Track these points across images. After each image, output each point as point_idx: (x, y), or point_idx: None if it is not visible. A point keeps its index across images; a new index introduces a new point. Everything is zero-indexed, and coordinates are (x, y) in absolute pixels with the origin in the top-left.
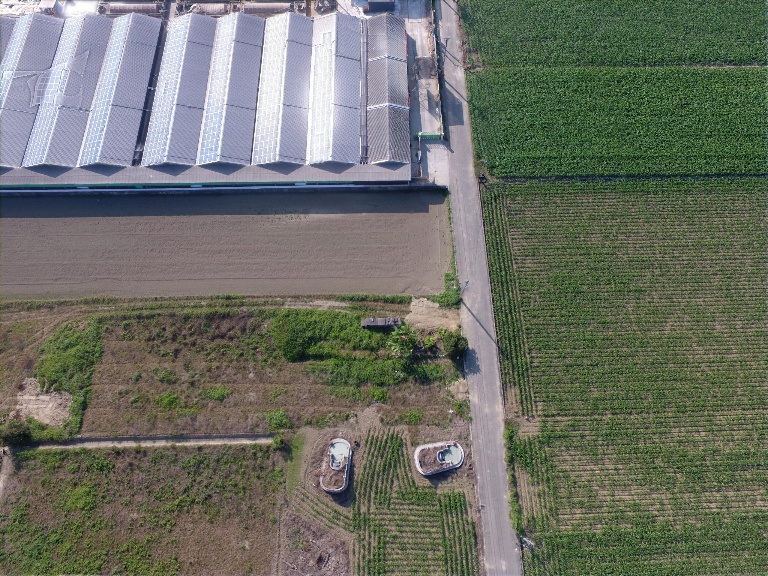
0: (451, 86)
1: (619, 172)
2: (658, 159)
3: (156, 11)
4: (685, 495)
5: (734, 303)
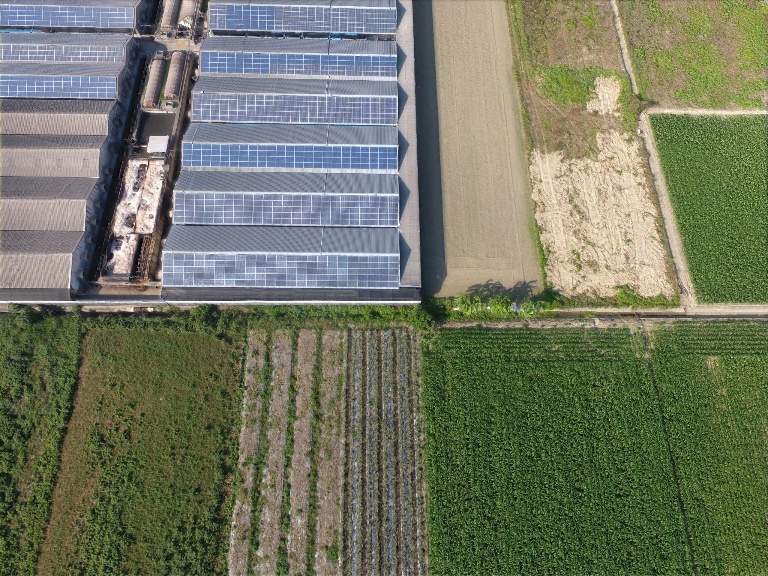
0: None
1: None
2: None
3: (184, 54)
4: None
5: None
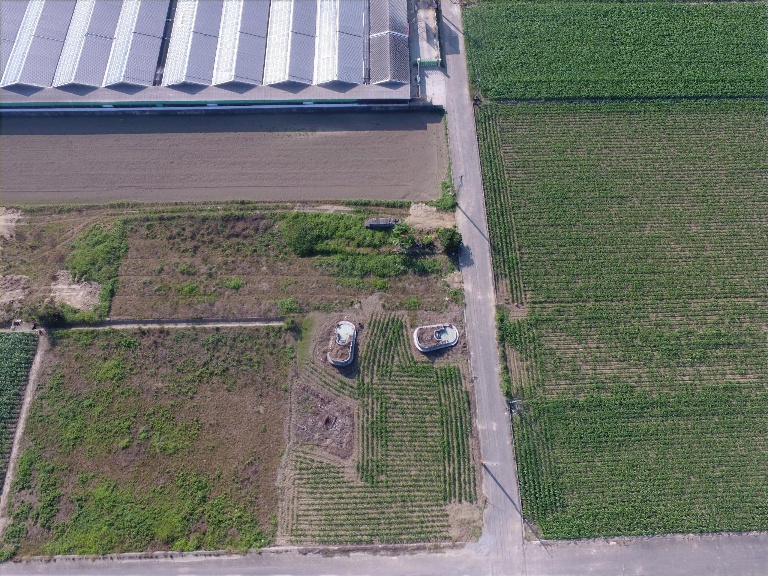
0: (448, 20)
1: (604, 94)
2: (641, 83)
3: None
4: (661, 369)
5: (709, 208)
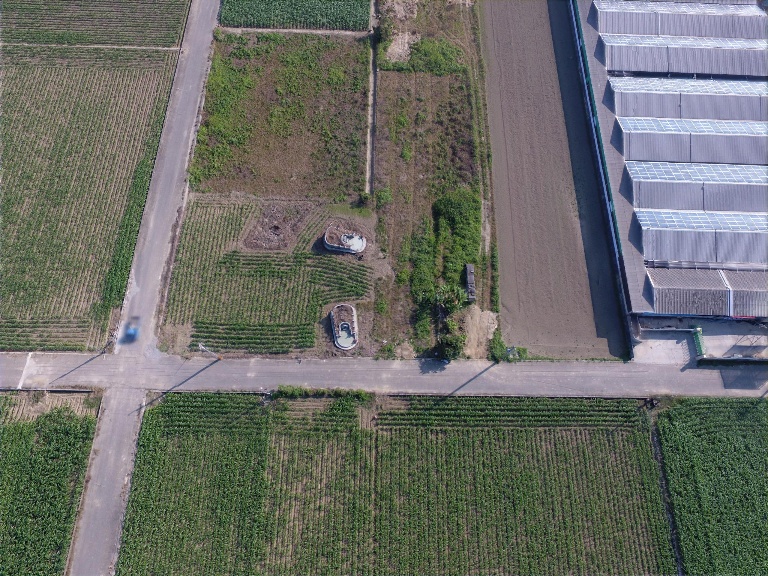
0: None
1: None
2: None
3: None
4: None
5: None
